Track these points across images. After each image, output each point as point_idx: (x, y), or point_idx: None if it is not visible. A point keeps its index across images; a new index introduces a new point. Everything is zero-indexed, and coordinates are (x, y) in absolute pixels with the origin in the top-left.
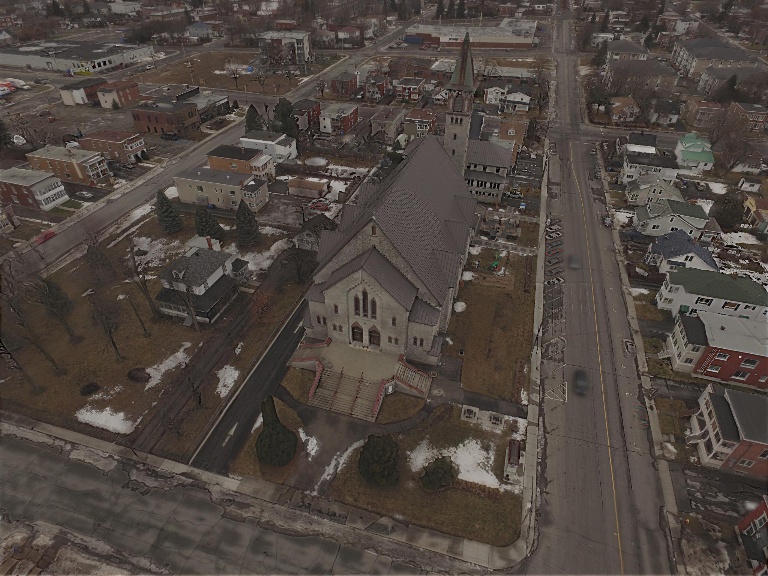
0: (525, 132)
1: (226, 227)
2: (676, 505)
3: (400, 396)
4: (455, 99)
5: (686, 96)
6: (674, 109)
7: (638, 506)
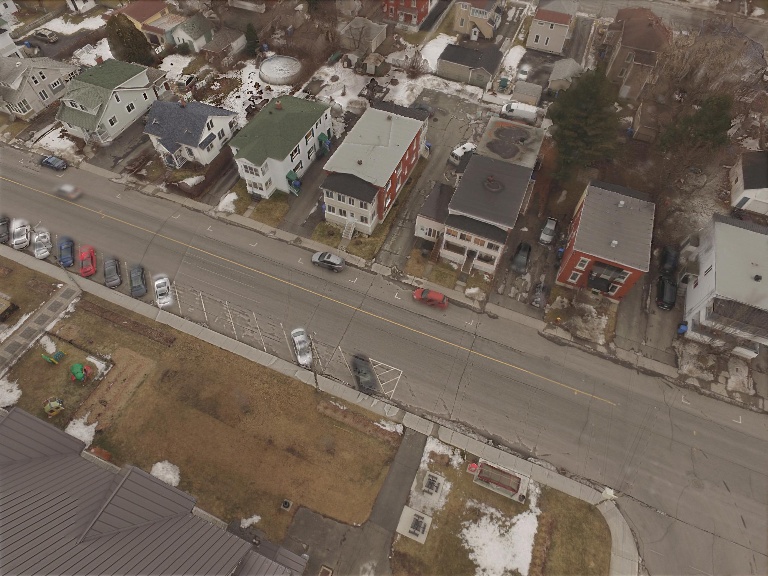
0: None
1: None
2: (537, 320)
3: None
4: None
5: None
6: None
7: (542, 355)
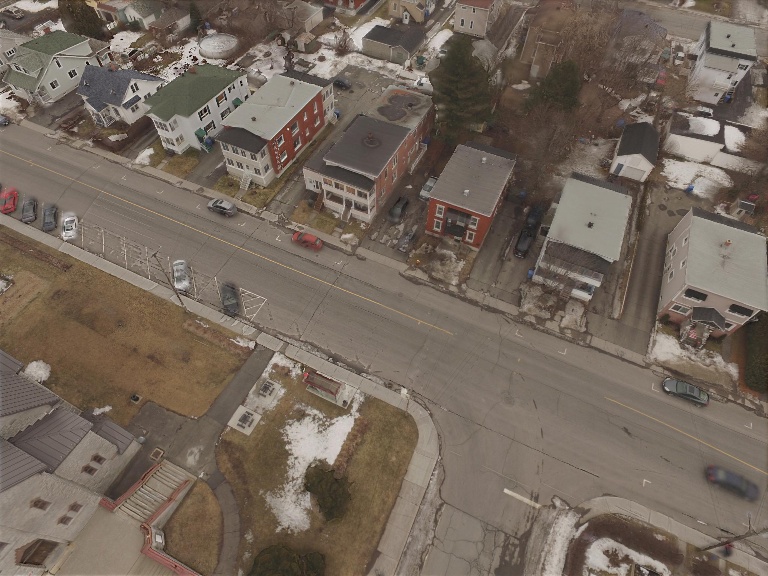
0: None
1: None
2: (400, 262)
3: (176, 523)
4: None
5: None
6: None
7: (397, 292)
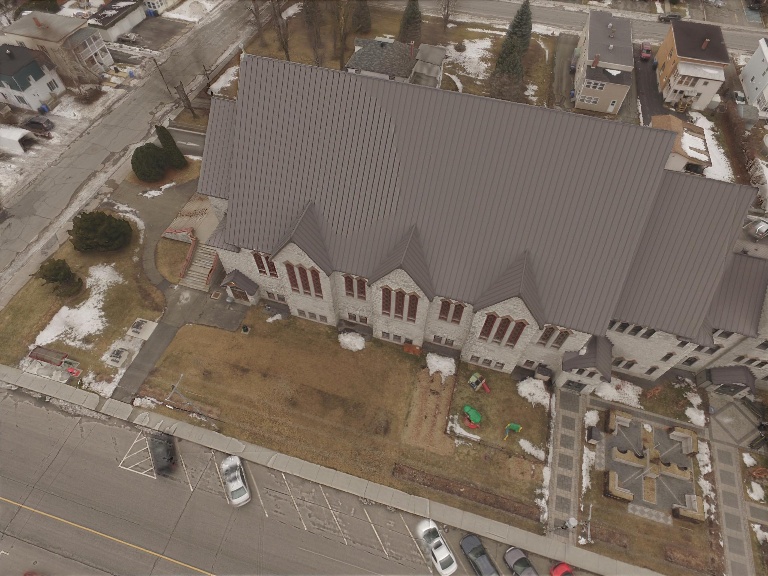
0: None
1: (531, 91)
2: None
3: None
4: None
5: None
6: None
7: None
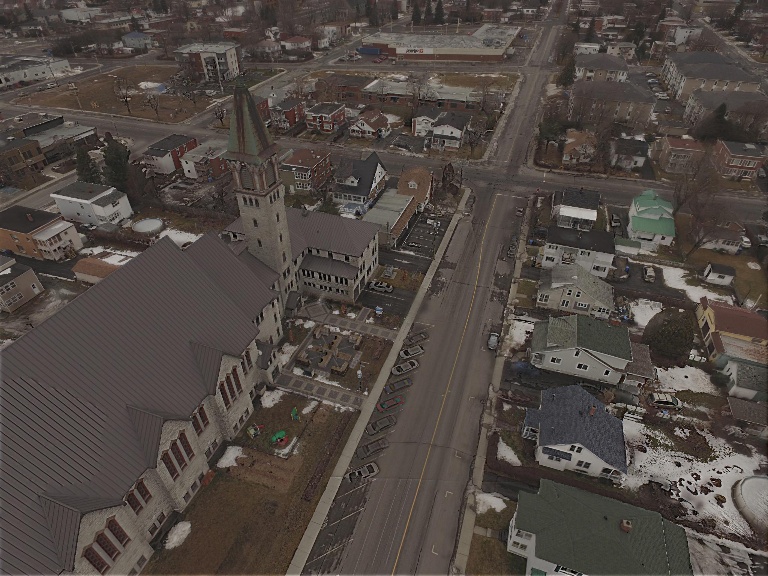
0: (437, 182)
1: None
2: None
3: None
4: (241, 172)
5: (664, 128)
6: (640, 149)
7: None
